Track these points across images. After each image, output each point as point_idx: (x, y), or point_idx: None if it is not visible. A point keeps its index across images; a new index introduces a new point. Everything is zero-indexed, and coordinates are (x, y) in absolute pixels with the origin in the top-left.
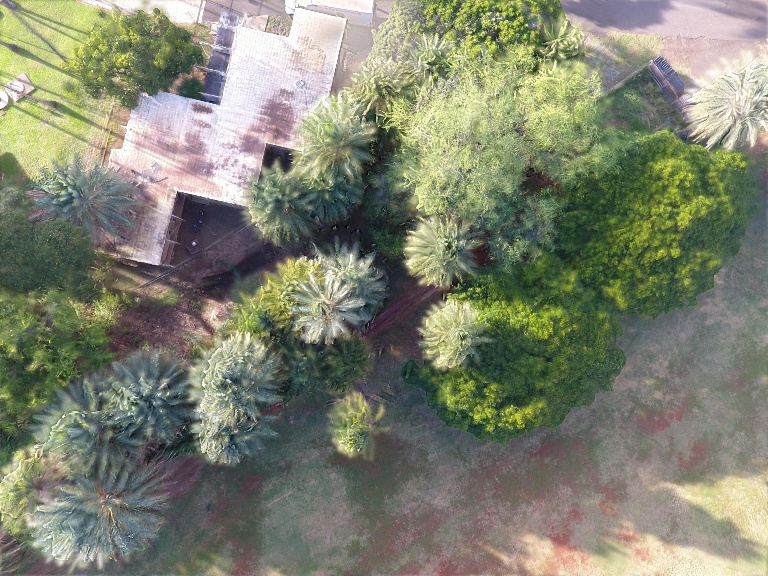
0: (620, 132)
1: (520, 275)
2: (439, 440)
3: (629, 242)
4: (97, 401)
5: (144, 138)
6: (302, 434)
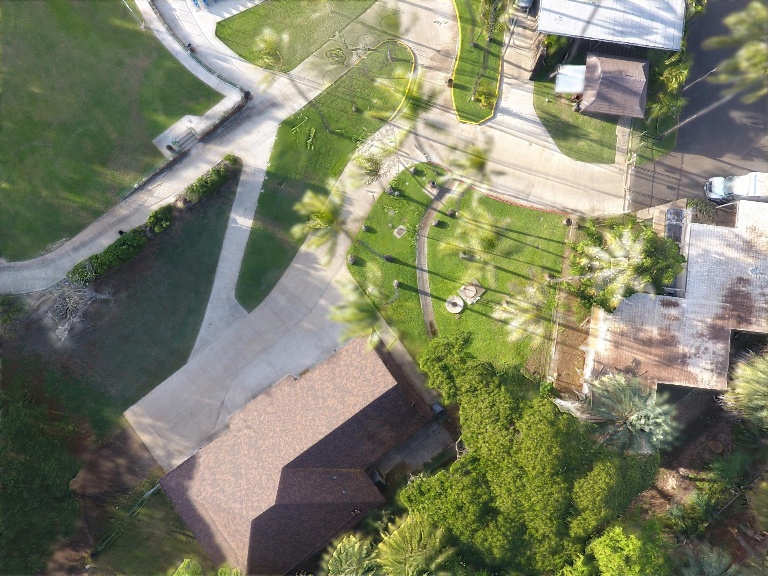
0: None
1: None
2: None
3: None
4: None
5: (621, 336)
6: None
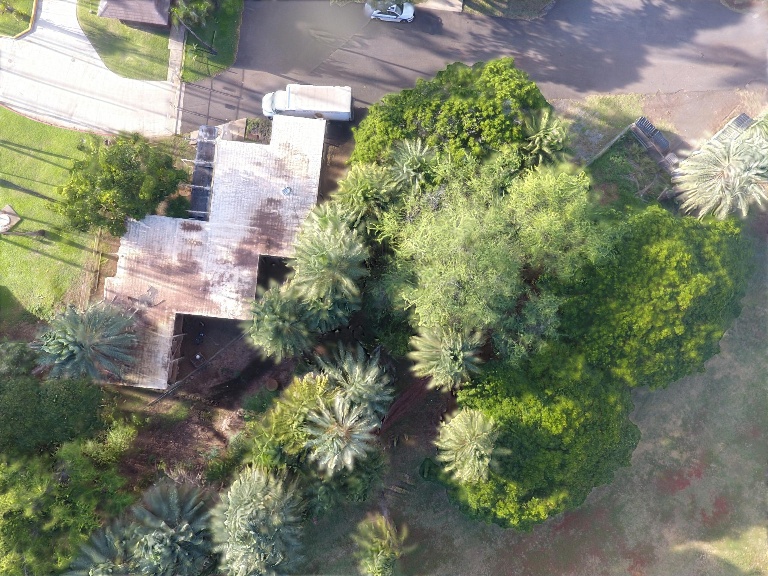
0: (611, 210)
1: (527, 367)
2: (463, 524)
3: (632, 324)
4: (122, 550)
5: (137, 263)
6: (326, 533)
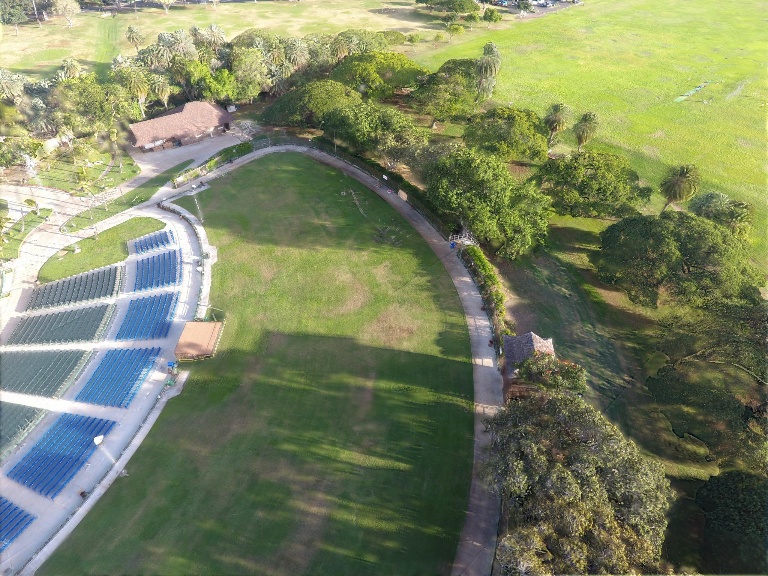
0: None
1: None
2: None
3: None
4: None
5: None
6: None
